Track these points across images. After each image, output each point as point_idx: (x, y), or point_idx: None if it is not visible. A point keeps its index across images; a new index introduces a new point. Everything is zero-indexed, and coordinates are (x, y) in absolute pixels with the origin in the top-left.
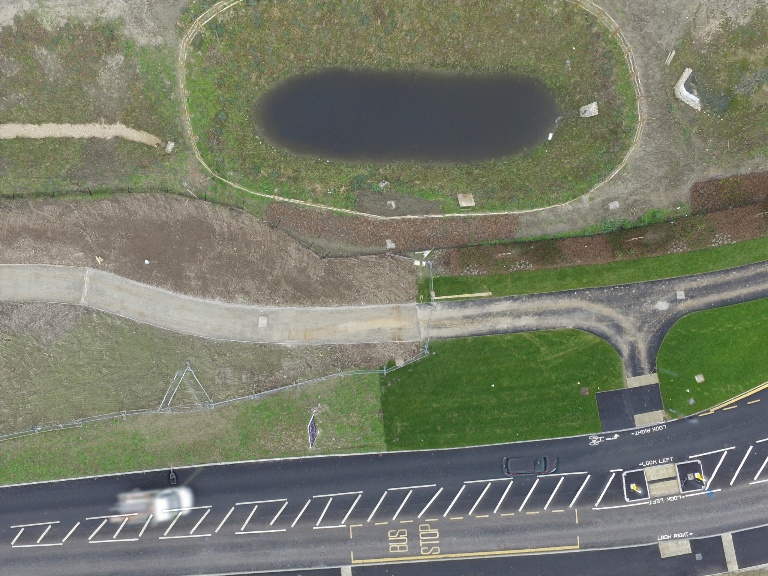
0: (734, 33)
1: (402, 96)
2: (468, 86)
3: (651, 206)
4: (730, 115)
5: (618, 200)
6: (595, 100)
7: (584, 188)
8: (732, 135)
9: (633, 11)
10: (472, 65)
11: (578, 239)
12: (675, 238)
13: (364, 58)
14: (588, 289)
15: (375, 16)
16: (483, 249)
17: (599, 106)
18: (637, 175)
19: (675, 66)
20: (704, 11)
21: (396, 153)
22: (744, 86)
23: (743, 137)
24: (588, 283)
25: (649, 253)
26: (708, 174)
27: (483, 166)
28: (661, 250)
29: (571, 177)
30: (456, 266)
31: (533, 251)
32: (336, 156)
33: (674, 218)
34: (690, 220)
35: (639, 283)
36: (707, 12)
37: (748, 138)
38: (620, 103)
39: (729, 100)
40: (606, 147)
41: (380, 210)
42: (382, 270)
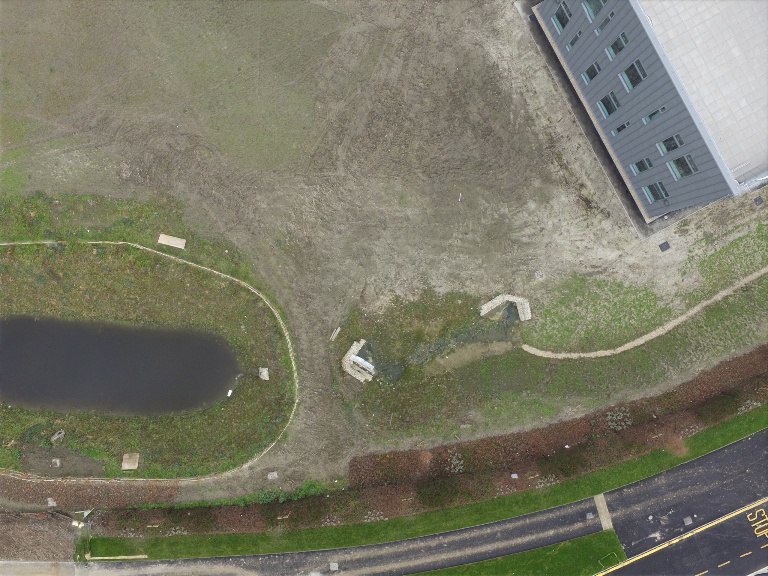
0: (406, 307)
1: (90, 343)
2: (155, 337)
3: (309, 478)
4: (402, 384)
5: (277, 471)
6: (267, 366)
7: (243, 458)
8: (398, 408)
9: (300, 287)
10: (154, 321)
11: (234, 508)
12: (330, 512)
13: (48, 309)
14: (243, 556)
15: (50, 277)
16: (141, 513)
17: (270, 373)
18: (297, 447)
19: (340, 342)
20: (372, 289)
21: (79, 401)
22: (418, 356)
23: (407, 412)
24: (242, 551)
25: (303, 525)
26: (367, 449)
27: (161, 420)
28: (315, 523)
29: (235, 444)
30: (114, 528)
31: (187, 519)
32: (19, 401)
33: (331, 491)
34: (343, 496)
35: (293, 553)
36: (376, 289)
37: (411, 414)
38: (285, 375)
39: (403, 369)
40: (270, 416)
41: (44, 468)
42: (42, 528)
